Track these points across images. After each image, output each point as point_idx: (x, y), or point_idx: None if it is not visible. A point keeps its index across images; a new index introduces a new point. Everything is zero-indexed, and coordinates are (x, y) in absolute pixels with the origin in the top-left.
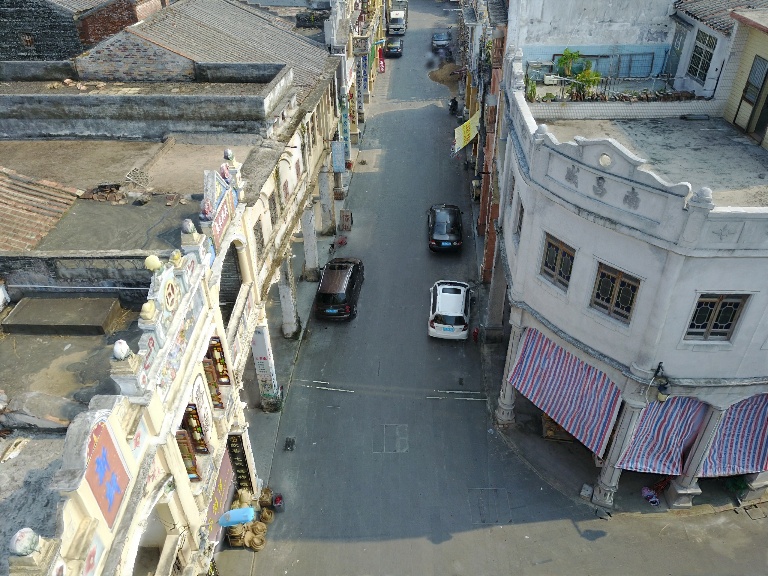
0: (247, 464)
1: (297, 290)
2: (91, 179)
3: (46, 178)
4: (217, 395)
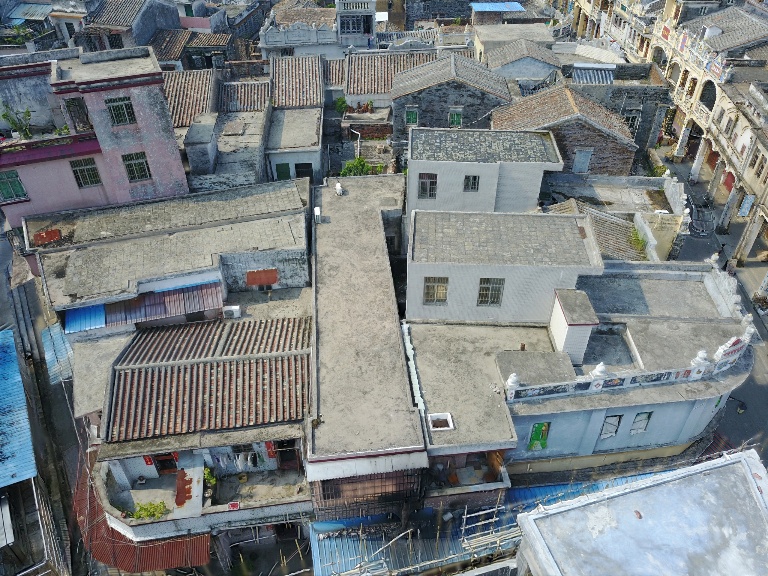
0: None
1: None
2: None
3: None
4: None
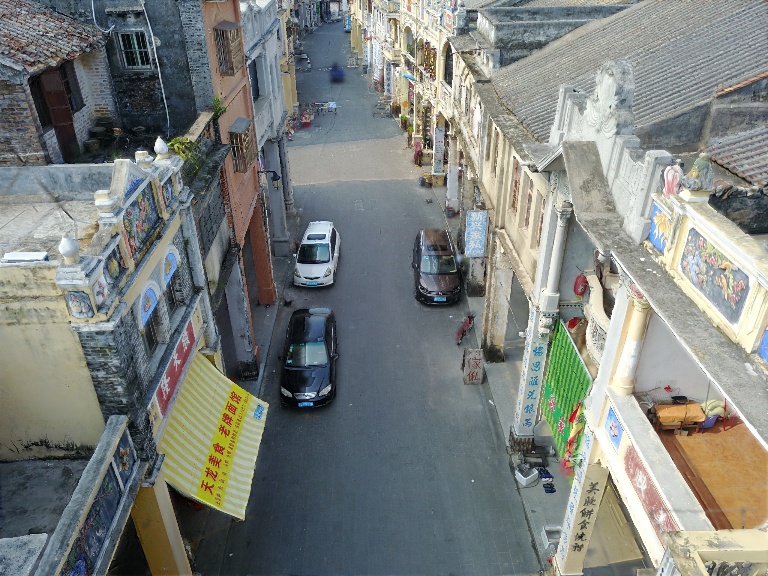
0: None
1: None
2: None
3: None
4: (432, 71)
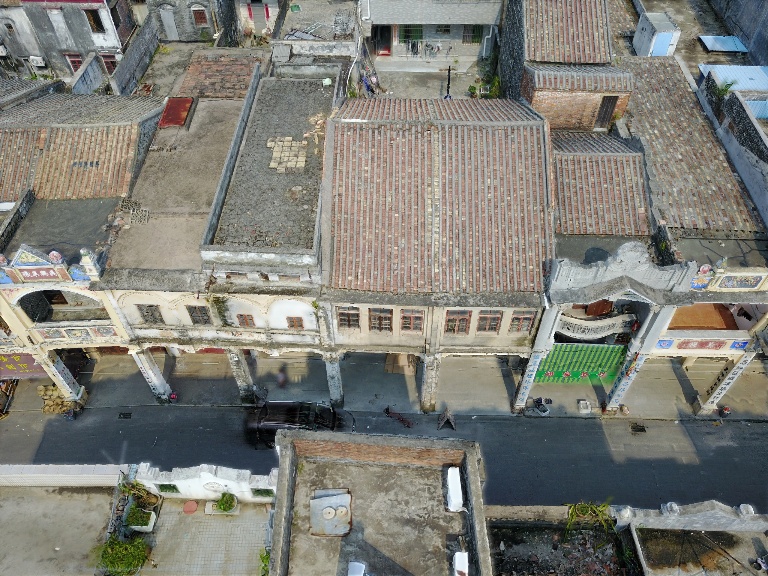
0: (53, 380)
1: (316, 391)
2: (156, 193)
3: (163, 172)
4: None
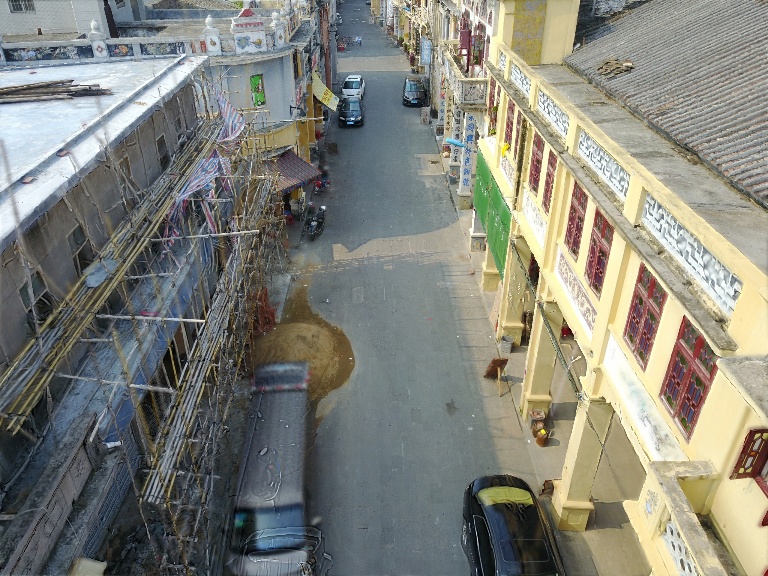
0: None
1: None
2: None
3: None
4: None
